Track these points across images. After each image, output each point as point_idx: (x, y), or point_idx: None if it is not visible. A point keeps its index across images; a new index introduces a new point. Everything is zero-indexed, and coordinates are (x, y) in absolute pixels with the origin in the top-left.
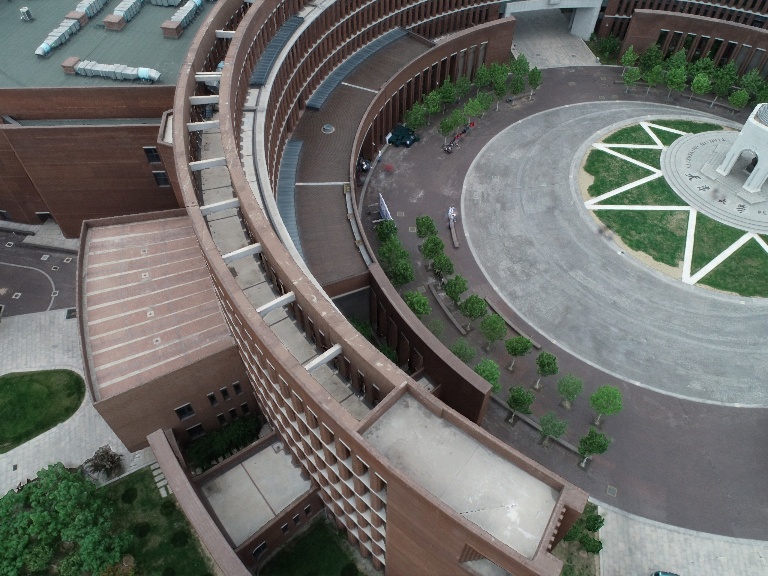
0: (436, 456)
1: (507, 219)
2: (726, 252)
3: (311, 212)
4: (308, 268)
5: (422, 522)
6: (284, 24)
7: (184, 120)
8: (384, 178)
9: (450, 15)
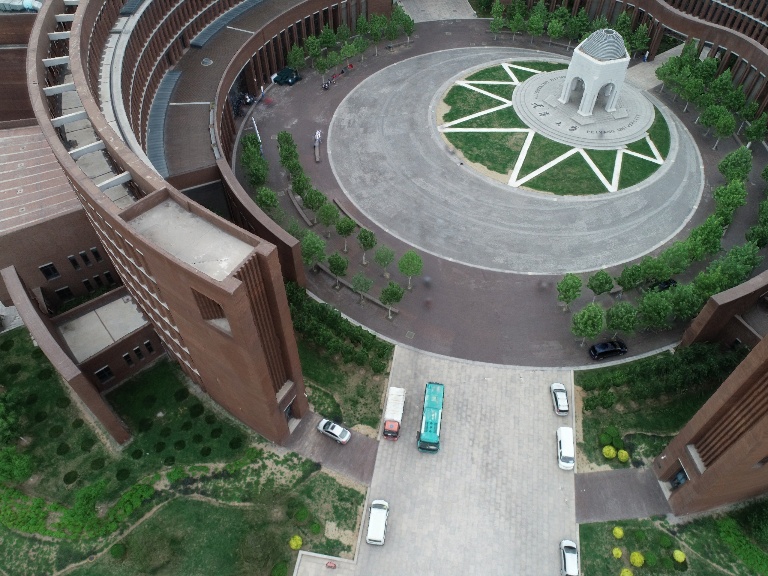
0: (179, 234)
1: (367, 140)
2: (552, 163)
3: (179, 124)
4: (167, 164)
5: (171, 285)
6: None
7: (44, 29)
8: (265, 110)
9: None
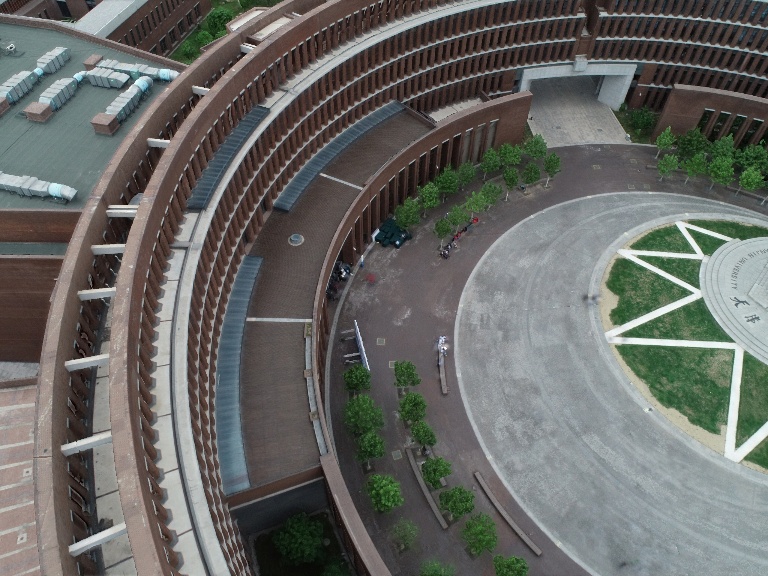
0: None
1: (509, 354)
2: None
3: (260, 363)
4: (245, 453)
5: None
6: (244, 117)
7: (72, 290)
8: (365, 290)
9: (457, 84)
